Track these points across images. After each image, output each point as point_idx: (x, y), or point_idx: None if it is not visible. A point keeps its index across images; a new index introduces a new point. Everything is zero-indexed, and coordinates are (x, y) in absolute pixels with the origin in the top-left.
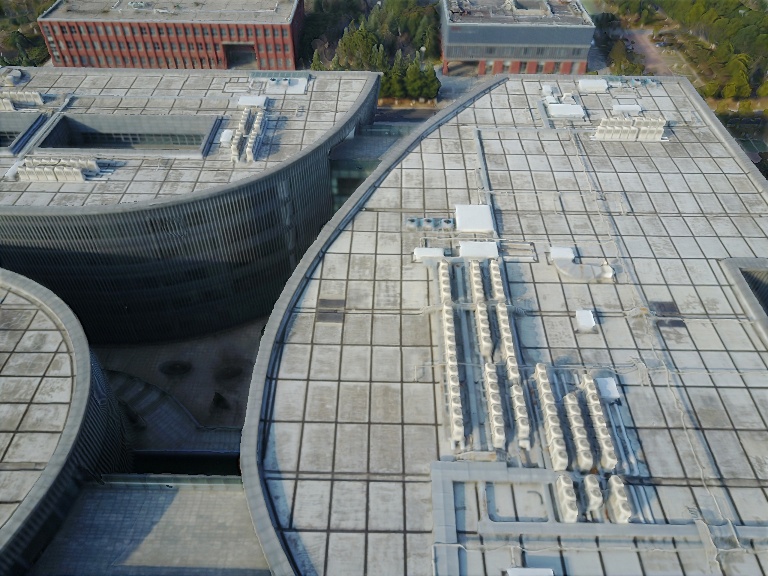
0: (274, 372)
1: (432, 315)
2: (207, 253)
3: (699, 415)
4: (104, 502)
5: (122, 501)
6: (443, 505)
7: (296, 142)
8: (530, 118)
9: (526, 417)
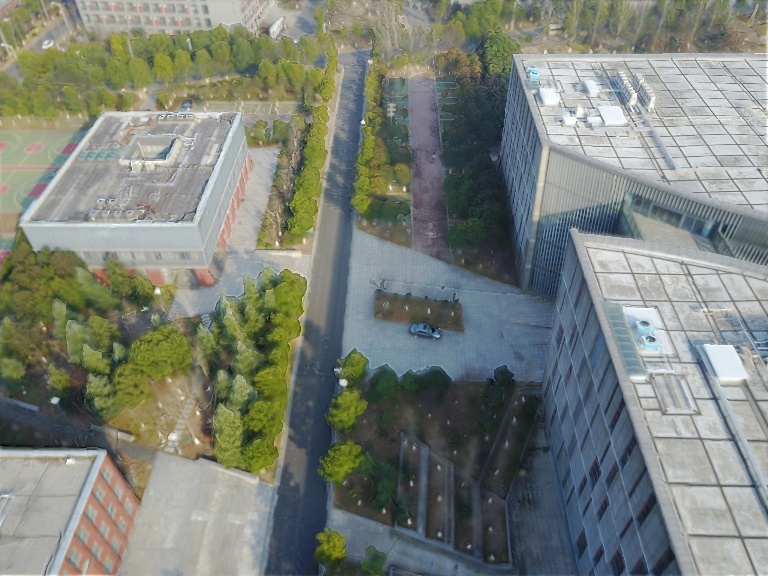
0: None
1: None
2: None
3: None
4: None
5: None
6: None
7: None
8: (637, 135)
9: None
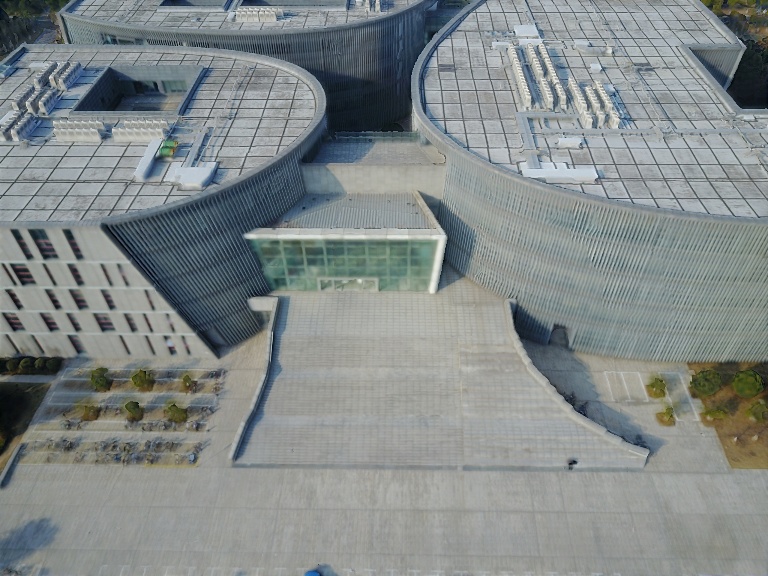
0: (422, 88)
1: (506, 69)
2: (351, 70)
3: (659, 99)
4: (337, 147)
5: (346, 147)
6: (523, 123)
7: (404, 3)
8: None
9: (564, 93)
